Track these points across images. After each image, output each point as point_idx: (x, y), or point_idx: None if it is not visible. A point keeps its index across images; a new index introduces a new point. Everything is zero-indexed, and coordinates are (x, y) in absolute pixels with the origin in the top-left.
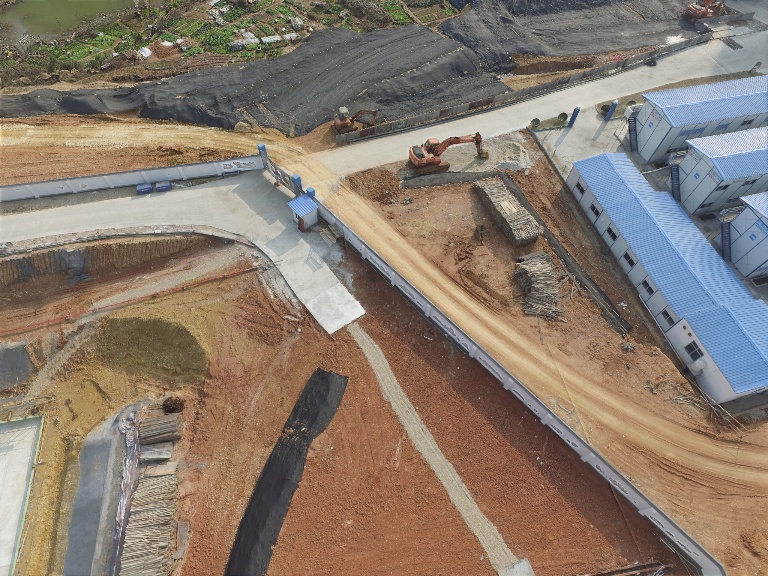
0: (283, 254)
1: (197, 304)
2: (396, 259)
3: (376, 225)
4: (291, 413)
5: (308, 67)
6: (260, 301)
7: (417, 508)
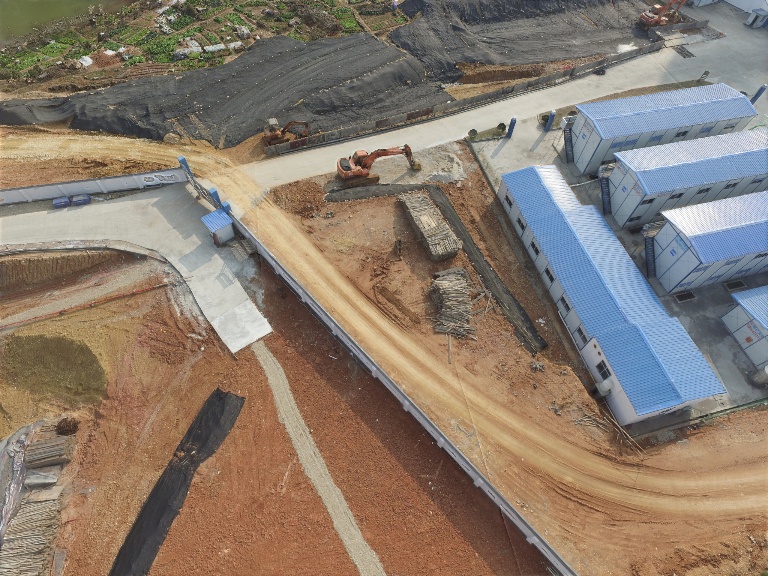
0: (195, 270)
1: (103, 321)
2: (310, 275)
3: (294, 240)
4: (185, 435)
5: (246, 77)
6: (166, 319)
7: (298, 536)
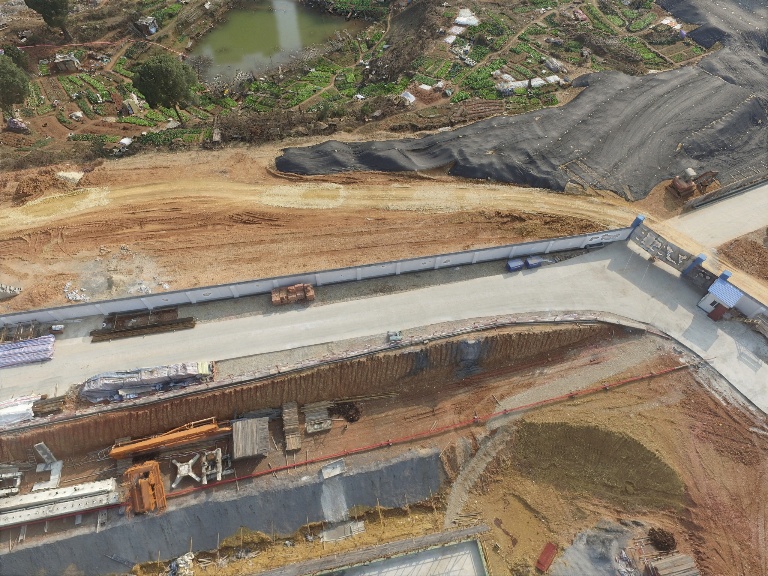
0: (709, 349)
1: (634, 409)
2: None
3: None
4: None
5: (605, 117)
6: (714, 409)
7: None
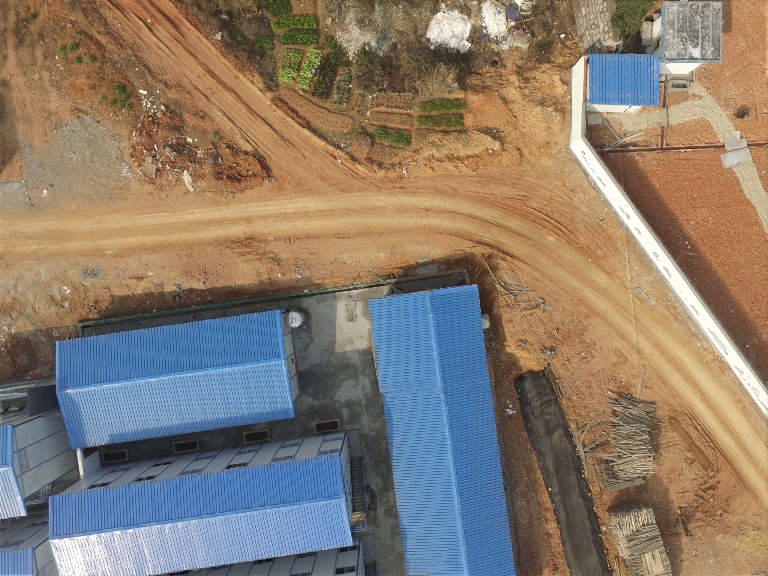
0: None
1: None
2: None
3: None
4: None
5: None
6: None
7: None
